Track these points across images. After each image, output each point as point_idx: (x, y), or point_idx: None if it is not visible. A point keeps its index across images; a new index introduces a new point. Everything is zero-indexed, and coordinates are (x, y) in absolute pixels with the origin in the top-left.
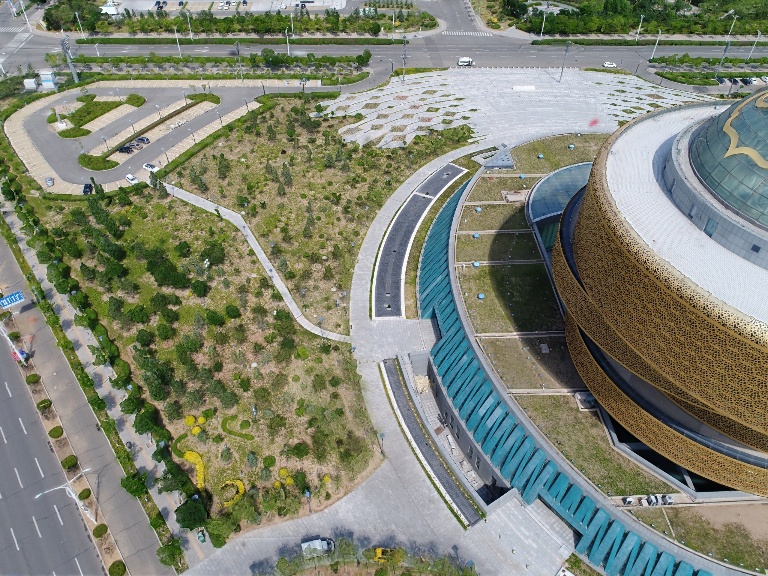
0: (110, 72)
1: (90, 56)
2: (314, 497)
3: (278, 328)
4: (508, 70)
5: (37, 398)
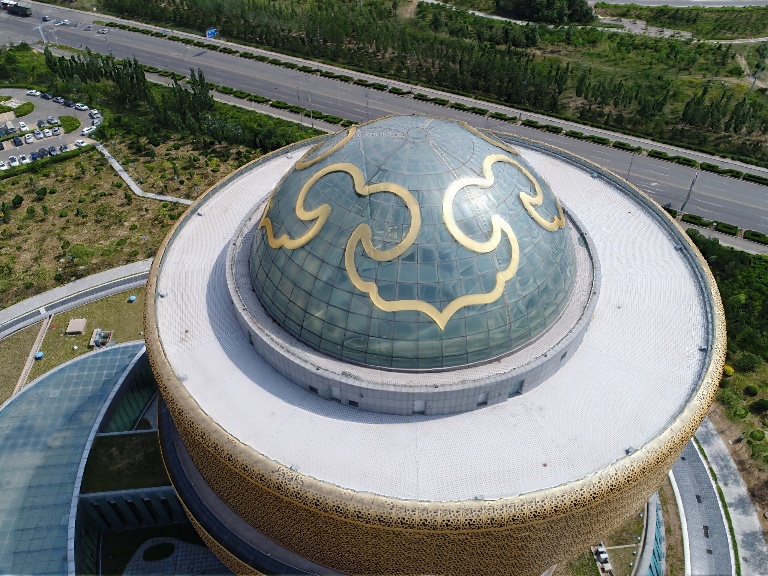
0: None
1: None
2: None
3: None
4: None
5: None
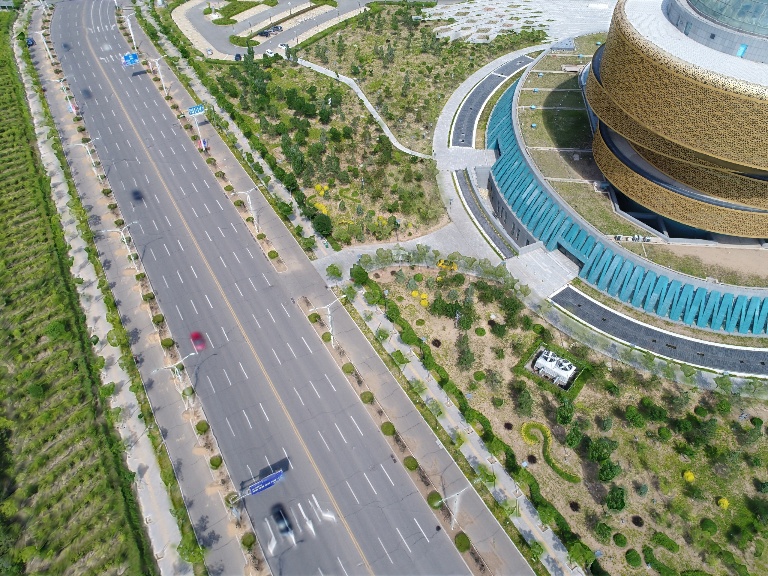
0: None
1: None
2: (401, 233)
3: (380, 147)
4: None
5: (214, 171)
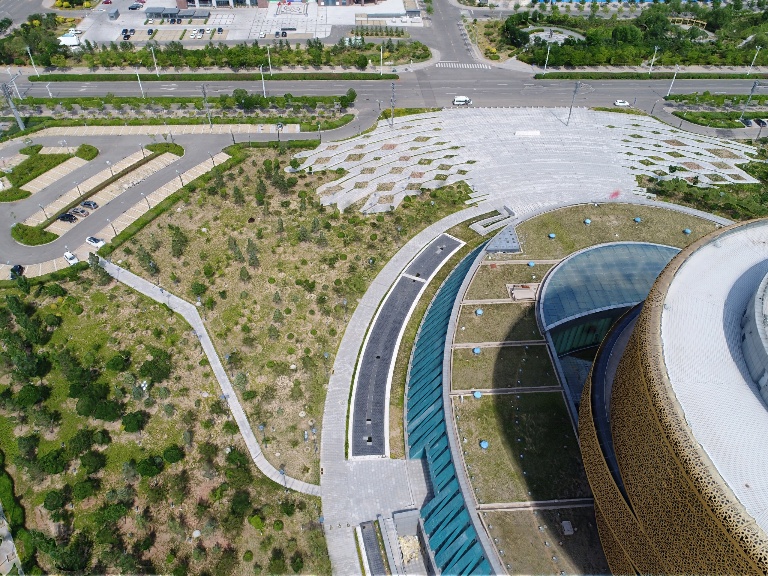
0: (62, 116)
1: (42, 96)
2: None
3: (230, 476)
4: (509, 110)
5: None
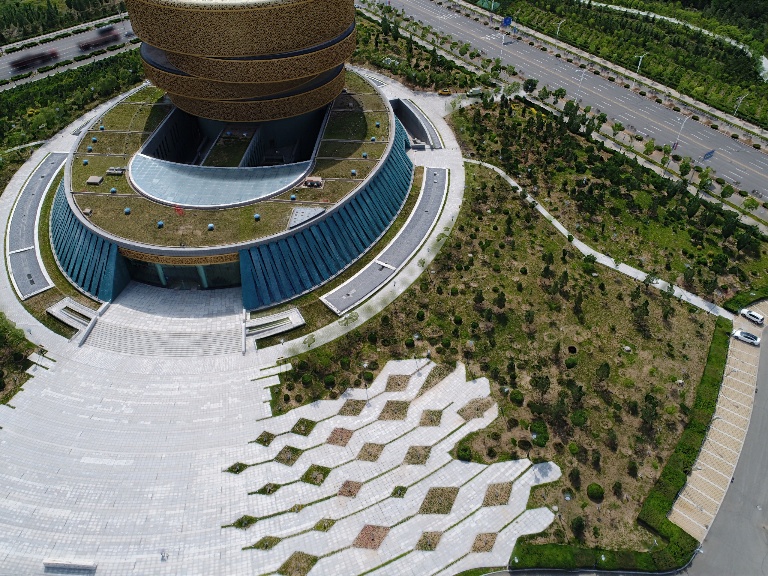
0: None
1: None
2: None
3: None
4: None
5: None
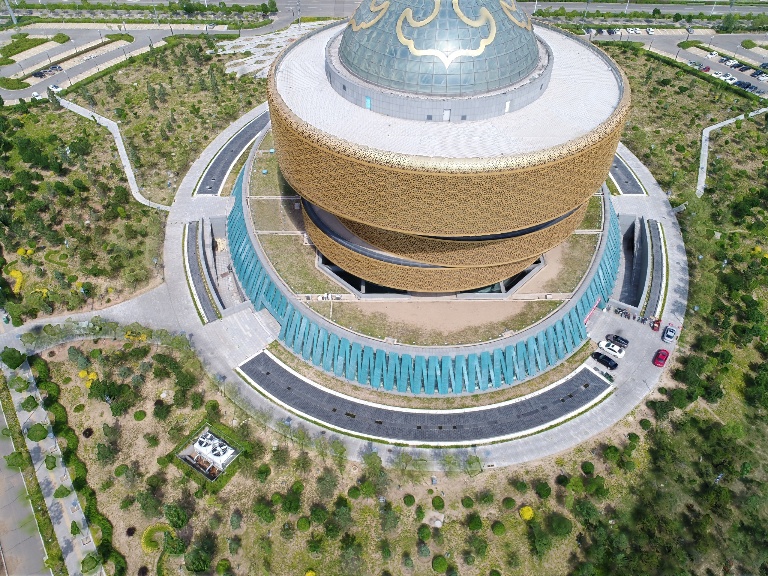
0: (46, 16)
1: (34, 4)
2: (98, 301)
3: None
4: None
5: None
